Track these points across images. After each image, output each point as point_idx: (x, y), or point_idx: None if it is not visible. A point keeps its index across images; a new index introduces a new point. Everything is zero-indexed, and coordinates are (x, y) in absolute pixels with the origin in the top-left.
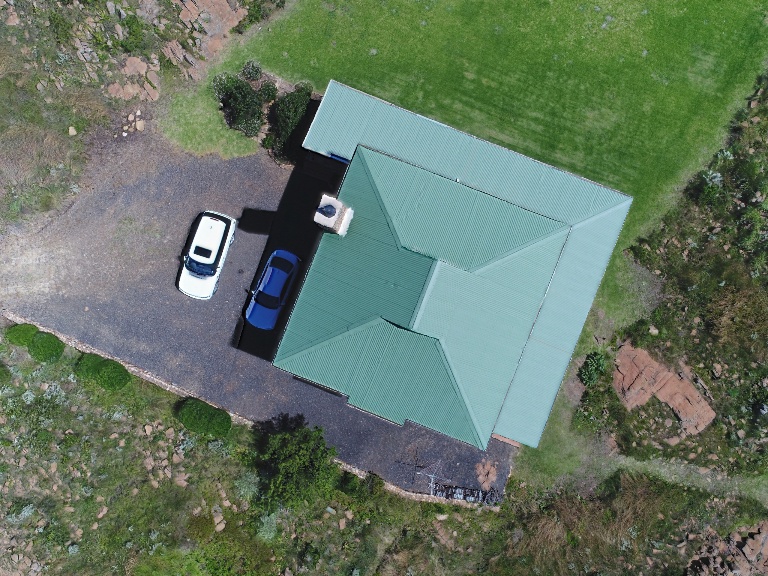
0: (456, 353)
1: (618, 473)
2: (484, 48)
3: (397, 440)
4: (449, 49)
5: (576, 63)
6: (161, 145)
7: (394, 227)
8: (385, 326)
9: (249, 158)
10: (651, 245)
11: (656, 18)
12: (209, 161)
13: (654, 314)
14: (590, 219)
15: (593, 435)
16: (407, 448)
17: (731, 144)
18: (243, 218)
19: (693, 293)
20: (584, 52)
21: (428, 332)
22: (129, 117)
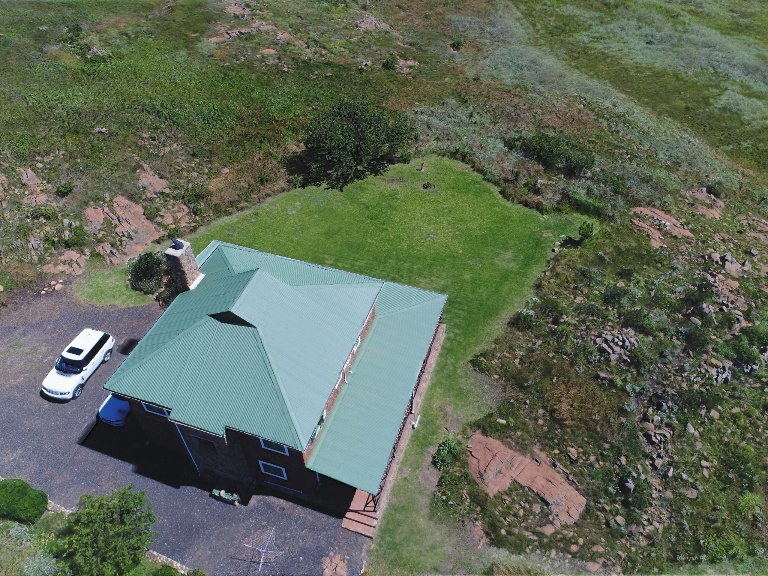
0: (273, 343)
1: (491, 566)
2: (341, 249)
3: (233, 533)
4: (314, 250)
5: (410, 256)
6: (71, 299)
7: (232, 268)
8: (211, 323)
9: (142, 307)
10: (486, 357)
11: (466, 236)
12: (107, 309)
13: (499, 408)
14: (413, 307)
15: (456, 523)
16: (243, 542)
17: (537, 295)
18: (123, 345)
19: (531, 389)
20: (415, 251)
21: (246, 317)
22: (52, 282)
